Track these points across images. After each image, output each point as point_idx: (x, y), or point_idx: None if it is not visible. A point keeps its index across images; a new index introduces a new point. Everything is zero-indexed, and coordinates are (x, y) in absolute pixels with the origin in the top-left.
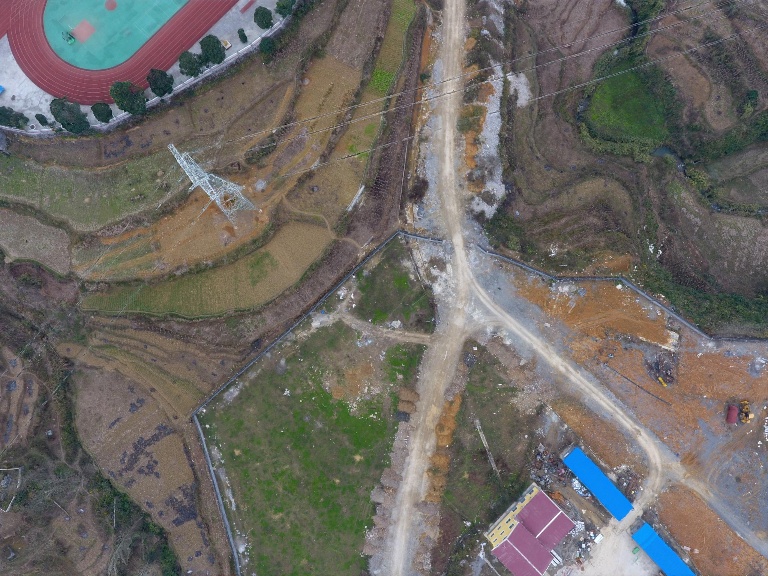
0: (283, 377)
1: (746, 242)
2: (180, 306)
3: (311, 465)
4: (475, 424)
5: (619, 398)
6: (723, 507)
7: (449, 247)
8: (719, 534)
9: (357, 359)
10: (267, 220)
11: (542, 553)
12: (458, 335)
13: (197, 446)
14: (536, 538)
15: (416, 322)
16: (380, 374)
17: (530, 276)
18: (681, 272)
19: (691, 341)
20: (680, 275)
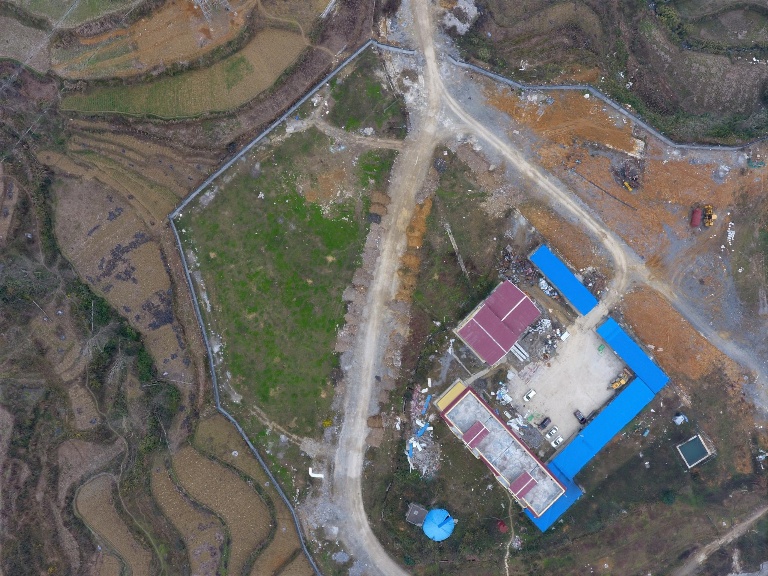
0: (258, 180)
1: (715, 79)
2: (157, 107)
3: (284, 266)
4: (445, 227)
5: (586, 203)
6: (687, 308)
7: (421, 59)
8: (683, 333)
9: (330, 164)
10: (242, 23)
11: (507, 334)
12: (429, 141)
13: (173, 251)
14: (501, 321)
15: (388, 129)
16: (352, 179)
17: (500, 86)
18: (651, 102)
19: (657, 149)
20: (649, 104)
